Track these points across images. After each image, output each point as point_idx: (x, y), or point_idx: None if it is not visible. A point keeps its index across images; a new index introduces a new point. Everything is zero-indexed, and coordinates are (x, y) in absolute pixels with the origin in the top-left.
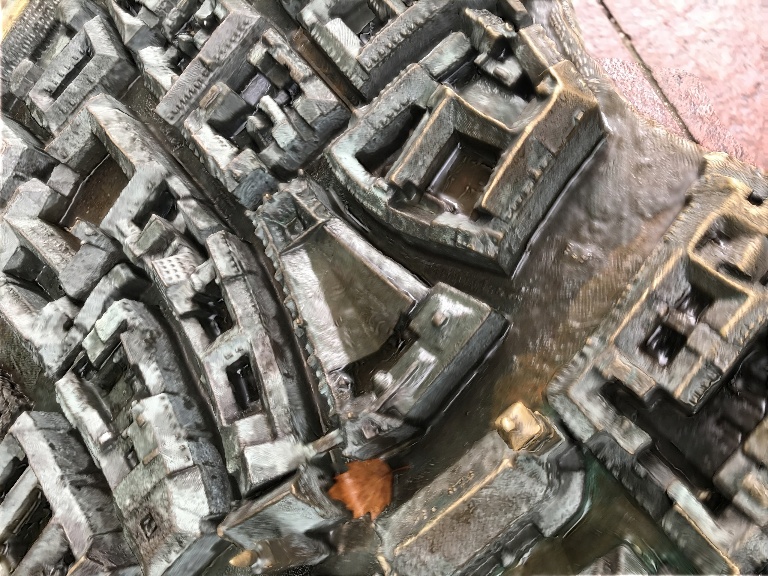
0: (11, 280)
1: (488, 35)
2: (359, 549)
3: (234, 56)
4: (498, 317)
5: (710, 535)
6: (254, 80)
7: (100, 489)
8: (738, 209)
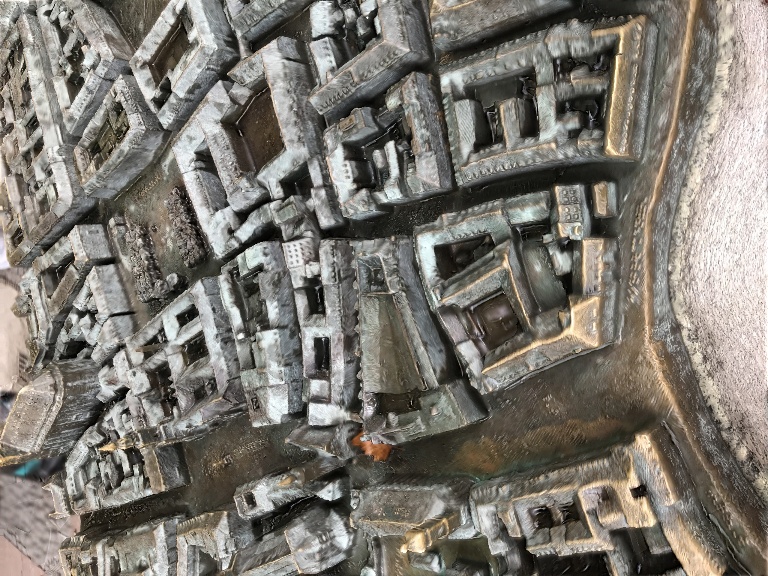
0: (199, 165)
1: (557, 229)
2: (363, 469)
3: (381, 74)
4: None
5: None
6: None
7: None
8: (621, 491)
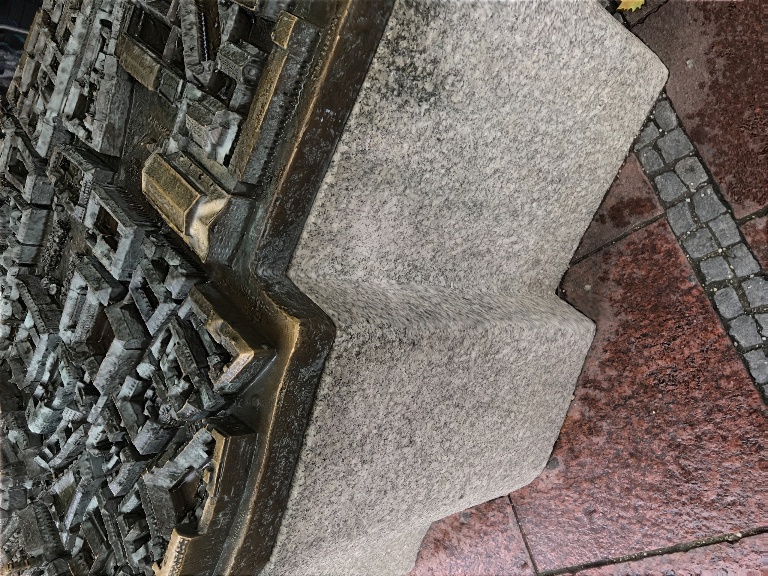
0: None
1: None
2: None
3: None
4: None
5: None
6: None
7: None
8: None
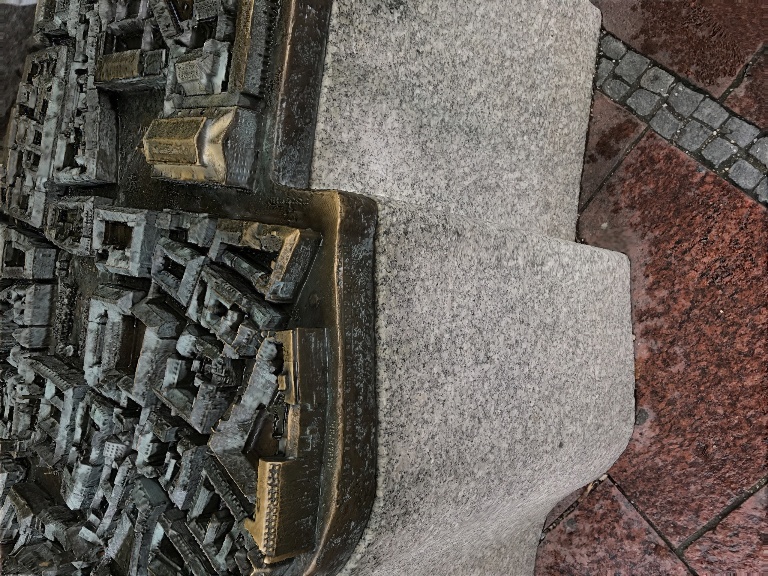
0: (103, 321)
1: None
2: None
3: None
4: None
5: None
6: None
7: None
8: None
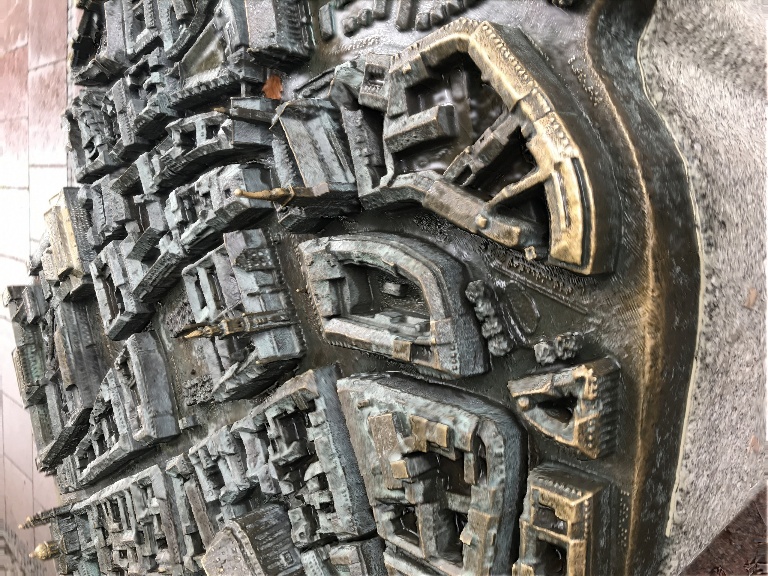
0: None
1: None
2: None
3: None
4: None
5: None
6: (140, 93)
7: None
8: None
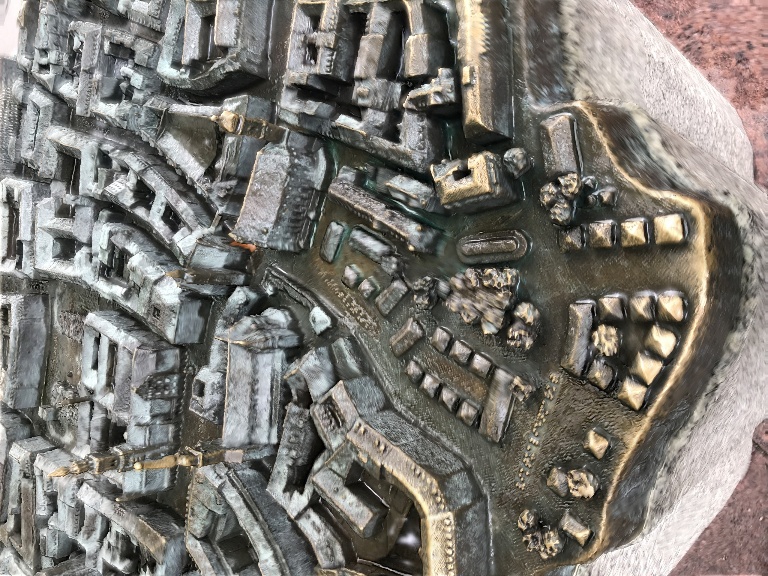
0: (57, 259)
1: None
2: (260, 266)
3: (101, 58)
4: (260, 100)
5: (356, 127)
6: (116, 64)
7: (144, 330)
8: None
